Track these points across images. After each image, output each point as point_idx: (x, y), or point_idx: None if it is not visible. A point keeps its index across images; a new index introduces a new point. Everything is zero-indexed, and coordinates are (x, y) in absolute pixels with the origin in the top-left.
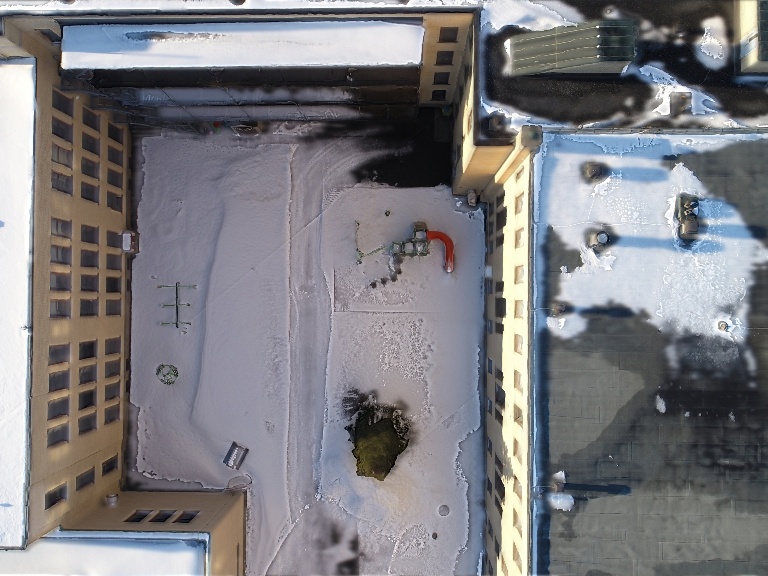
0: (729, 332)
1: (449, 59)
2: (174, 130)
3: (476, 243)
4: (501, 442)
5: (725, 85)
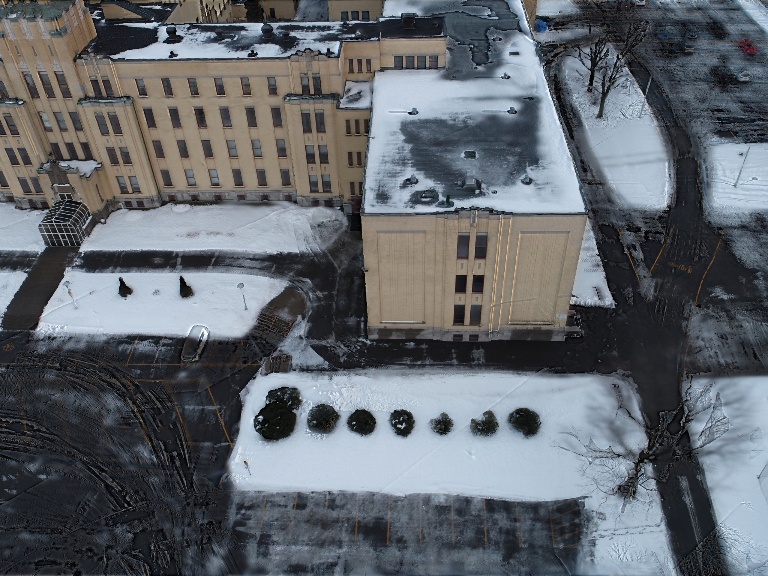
0: None
1: None
2: None
3: None
4: None
5: None
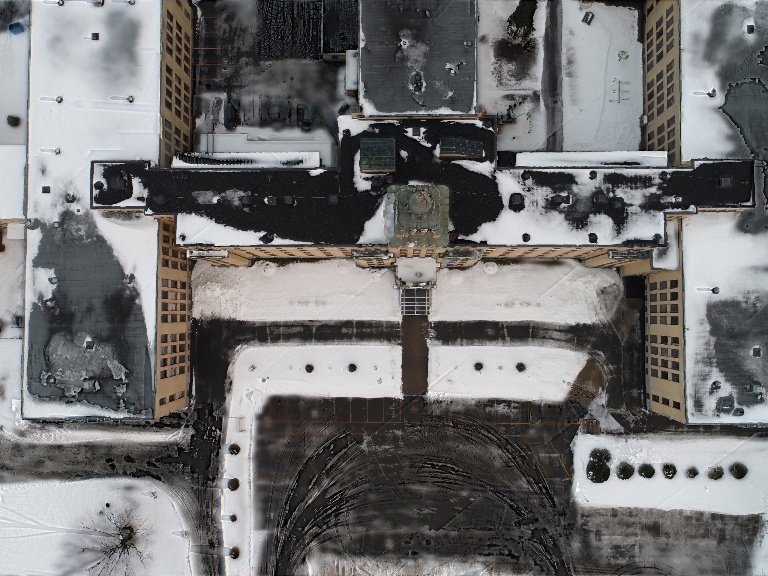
0: (403, 41)
1: None
2: None
3: None
4: None
5: (400, 139)
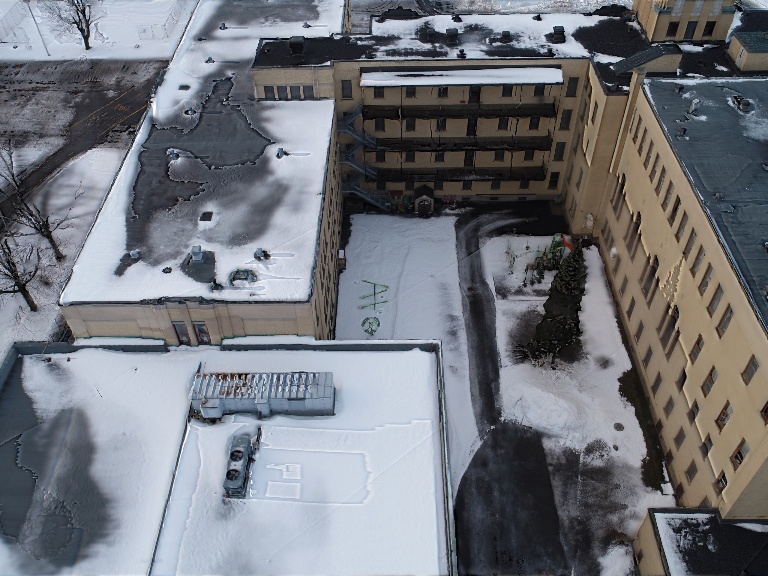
0: None
1: (567, 126)
2: None
3: (596, 262)
4: (661, 294)
5: None
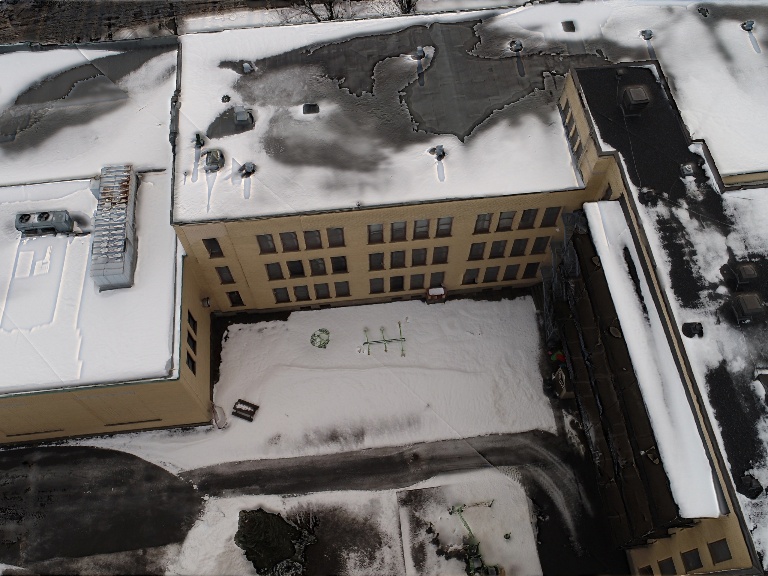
0: None
1: (692, 567)
2: (545, 320)
3: None
4: None
5: None
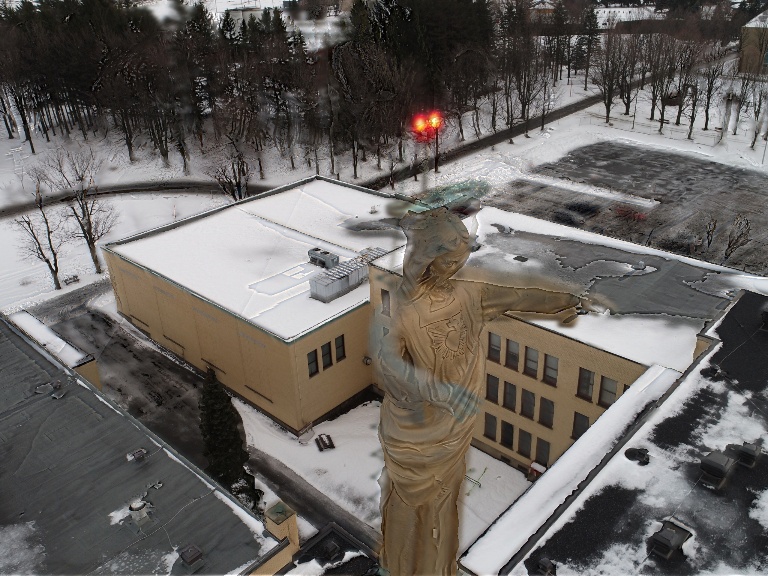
0: None
1: None
2: None
3: None
4: None
5: None
